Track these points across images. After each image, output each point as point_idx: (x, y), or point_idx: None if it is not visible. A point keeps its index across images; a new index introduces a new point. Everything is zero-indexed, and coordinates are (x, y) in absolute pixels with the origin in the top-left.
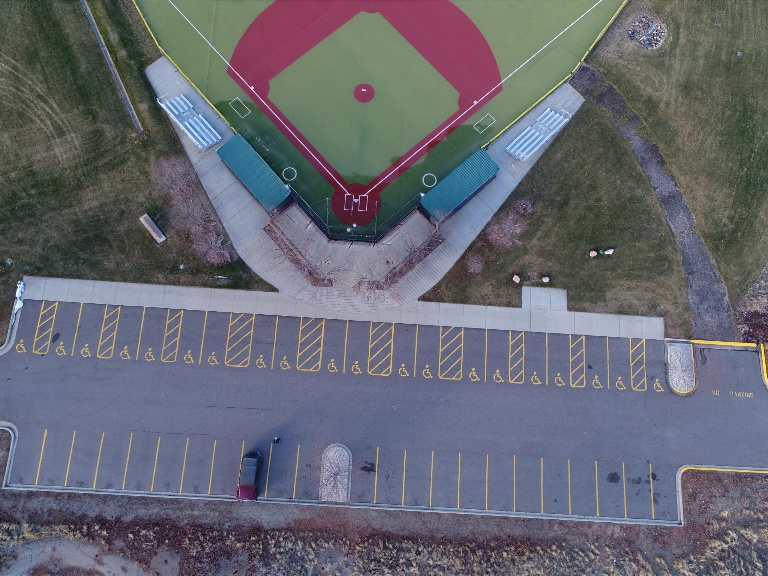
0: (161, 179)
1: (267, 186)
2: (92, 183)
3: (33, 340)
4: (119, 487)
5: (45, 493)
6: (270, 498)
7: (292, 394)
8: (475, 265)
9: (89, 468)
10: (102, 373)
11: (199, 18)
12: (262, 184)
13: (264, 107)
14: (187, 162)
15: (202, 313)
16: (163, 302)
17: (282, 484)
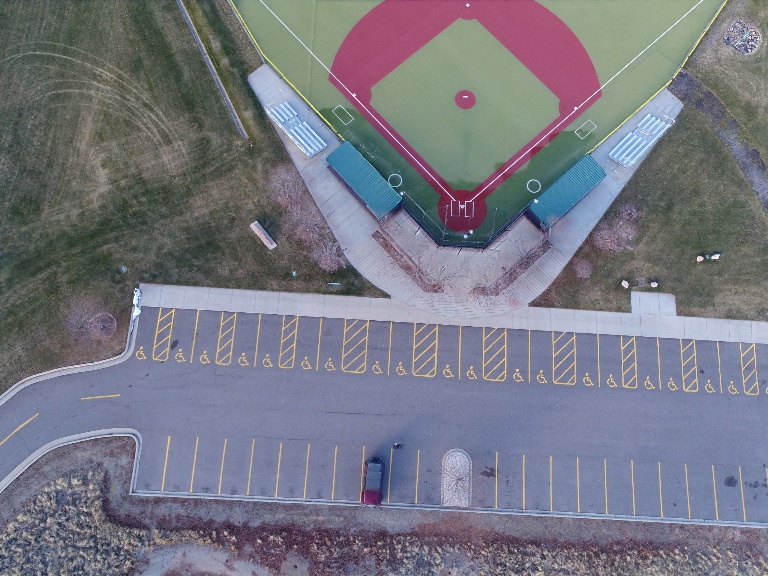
0: (269, 186)
1: (378, 193)
2: (201, 190)
3: (152, 347)
4: (244, 493)
5: (172, 499)
6: (393, 503)
7: (409, 400)
8: (583, 270)
9: (213, 474)
10: (222, 379)
11: (299, 26)
12: (373, 191)
13: (367, 114)
14: (293, 169)
15: (317, 319)
16: (278, 309)
17: (404, 489)
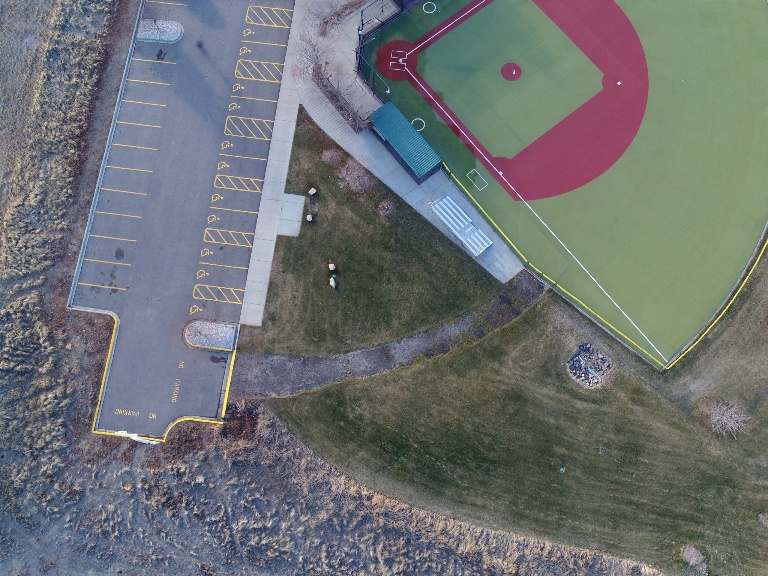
0: None
1: None
2: None
3: None
4: None
5: None
6: None
7: (229, 1)
8: (329, 156)
9: None
10: None
11: None
12: None
13: None
14: None
15: None
16: None
17: None
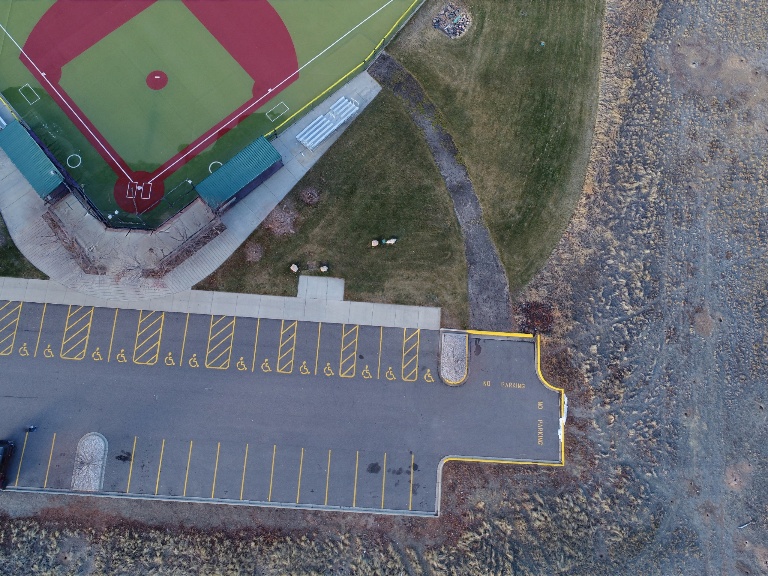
0: None
1: (41, 173)
2: None
3: None
4: None
5: None
6: (20, 487)
7: (53, 382)
8: (253, 254)
9: None
10: None
11: None
12: (36, 171)
13: (54, 93)
14: None
15: None
16: None
17: (34, 473)
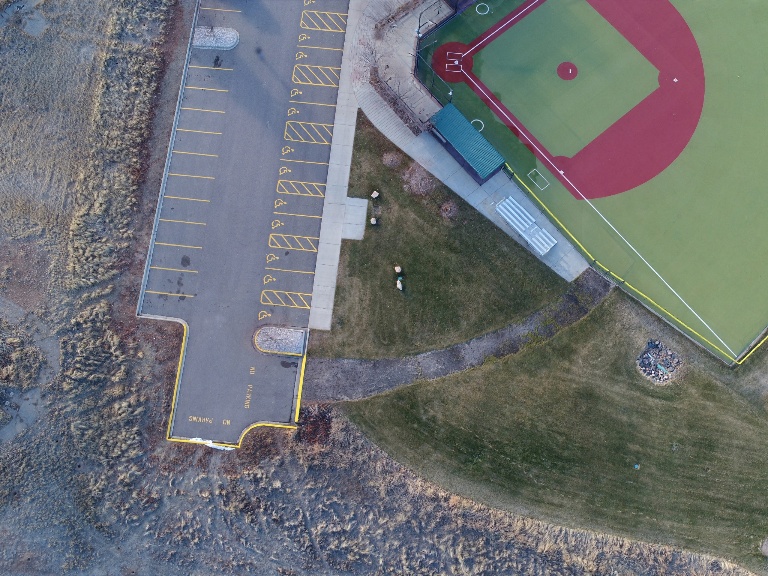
0: None
1: None
2: None
3: None
4: None
5: None
6: None
7: (283, 7)
8: (390, 159)
9: None
10: None
11: None
12: None
13: None
14: None
15: None
16: None
17: None
